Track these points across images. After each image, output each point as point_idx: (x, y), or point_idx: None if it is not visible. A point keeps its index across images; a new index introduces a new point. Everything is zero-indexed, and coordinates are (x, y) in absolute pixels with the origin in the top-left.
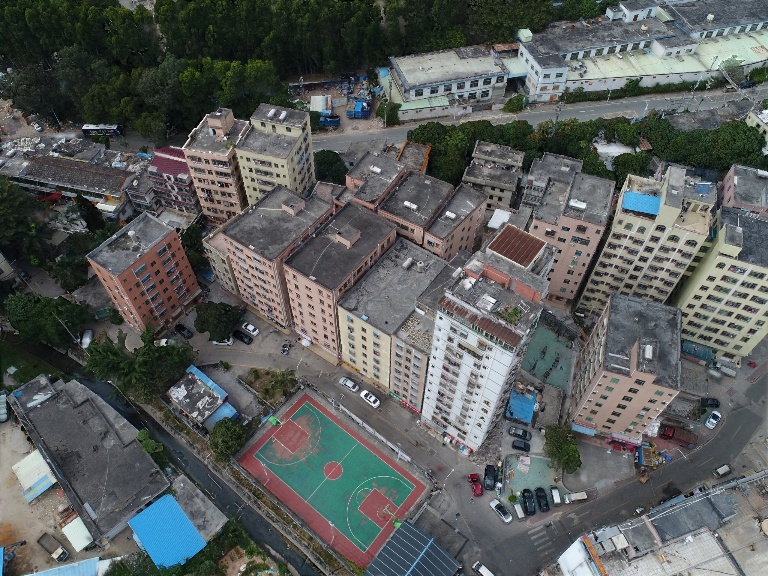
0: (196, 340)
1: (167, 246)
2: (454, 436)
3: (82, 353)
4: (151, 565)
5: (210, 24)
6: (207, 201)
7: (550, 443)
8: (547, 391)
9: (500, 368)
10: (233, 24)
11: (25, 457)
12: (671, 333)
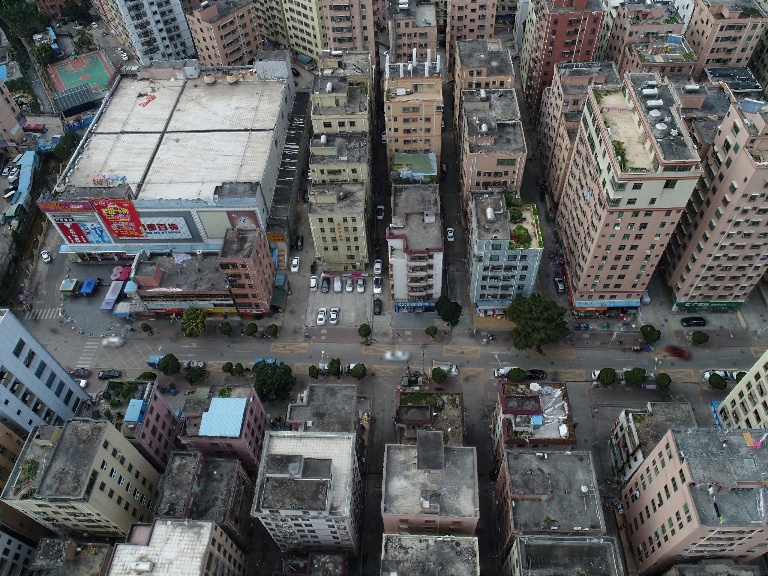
0: (67, 26)
1: None
2: None
3: None
4: None
5: None
6: None
7: None
8: None
9: None
10: None
11: None
12: None
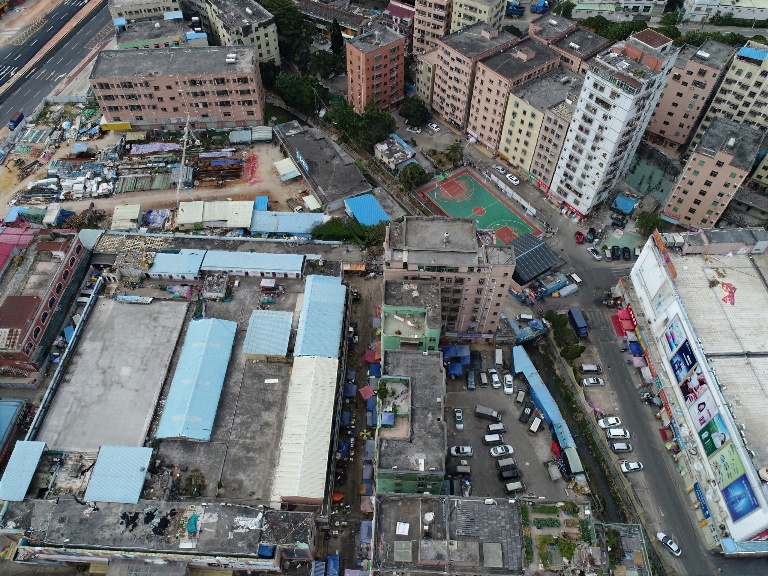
0: None
1: (397, 48)
2: (571, 204)
3: (318, 120)
4: (356, 224)
5: None
6: (419, 41)
7: (642, 218)
8: (647, 198)
9: (621, 114)
10: None
11: (282, 160)
12: (754, 146)
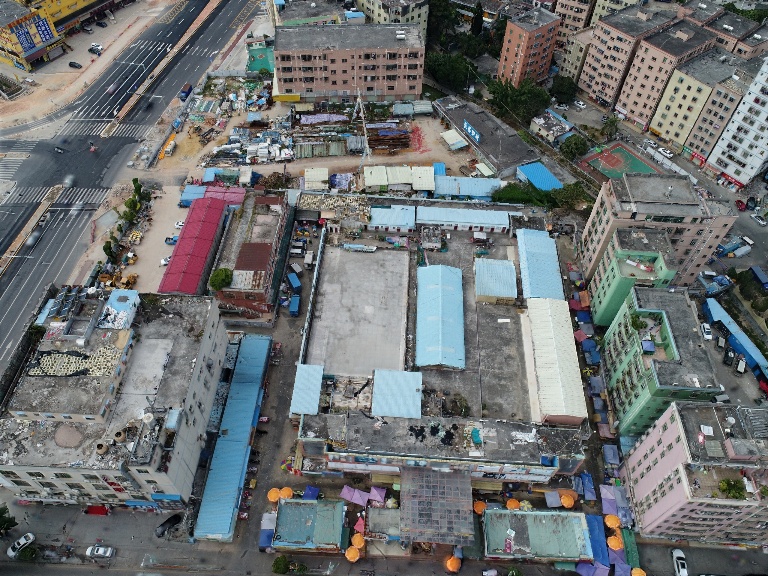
0: None
1: (553, 28)
2: (730, 174)
3: (467, 97)
4: (532, 189)
5: None
6: None
7: None
8: None
9: None
10: None
11: (447, 131)
12: None
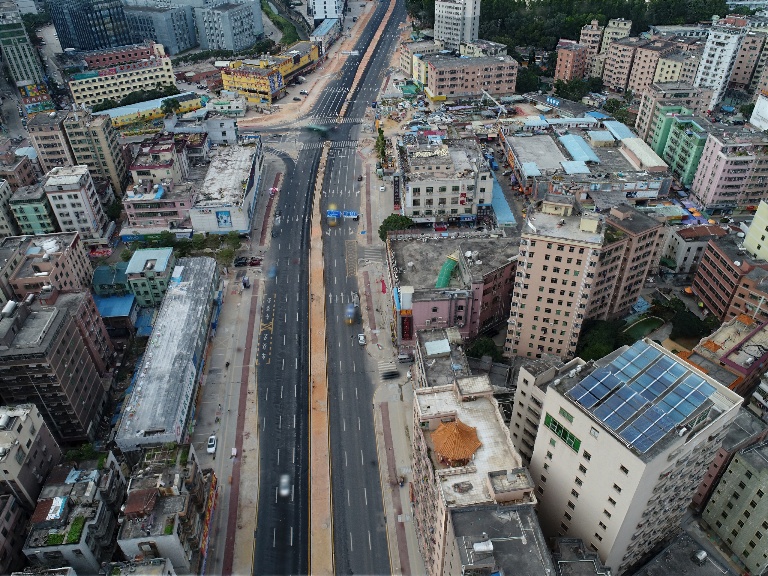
0: None
1: (584, 51)
2: None
3: None
4: None
5: (573, 6)
6: None
7: (742, 107)
8: None
9: (731, 46)
10: (583, 6)
11: (537, 105)
12: None
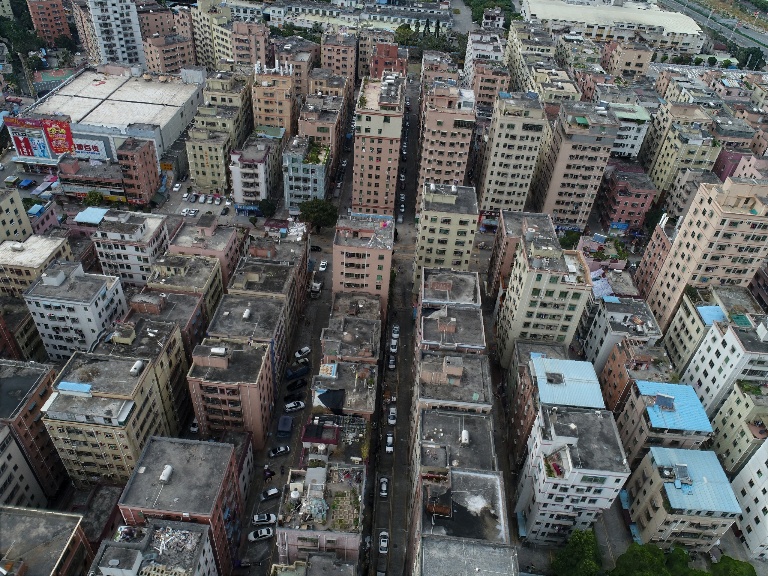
0: (57, 52)
1: (56, 5)
2: None
3: None
4: None
5: None
6: None
7: None
8: None
9: None
10: None
11: None
12: None
